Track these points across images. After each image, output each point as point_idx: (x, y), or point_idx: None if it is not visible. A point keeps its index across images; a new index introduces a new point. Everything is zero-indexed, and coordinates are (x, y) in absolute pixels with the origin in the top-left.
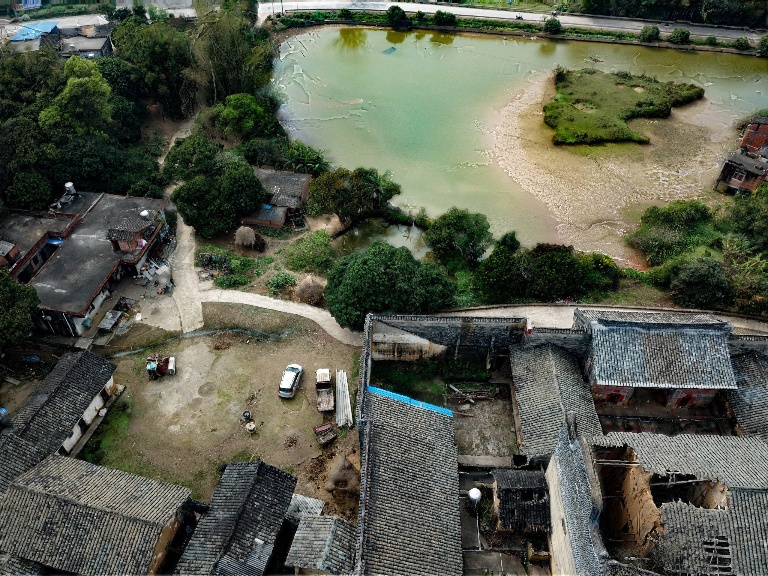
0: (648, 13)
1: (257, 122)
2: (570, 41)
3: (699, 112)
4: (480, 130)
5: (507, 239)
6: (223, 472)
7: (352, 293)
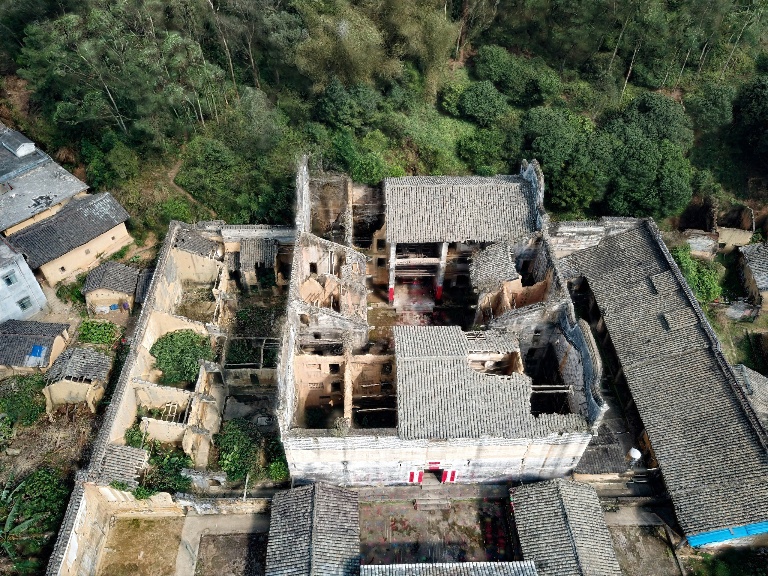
0: None
1: None
2: None
3: None
4: None
5: None
6: None
7: None
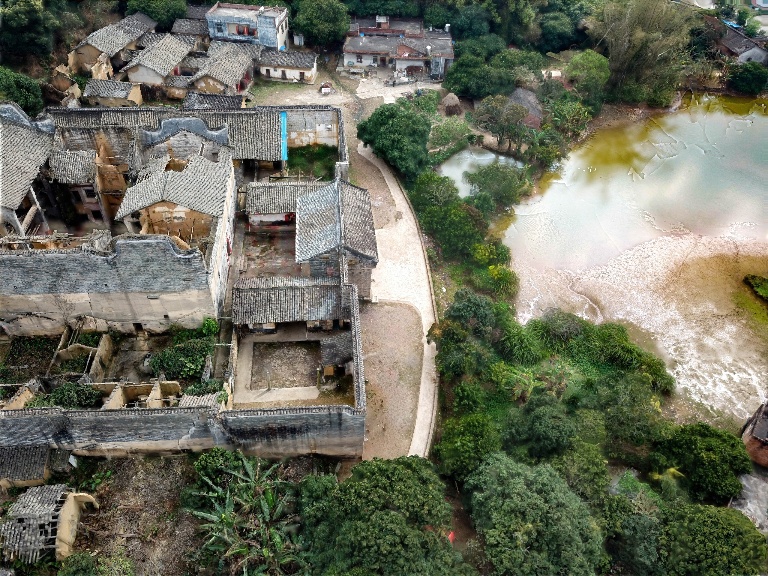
0: None
1: None
2: None
3: None
4: (729, 225)
5: (479, 193)
6: None
7: None
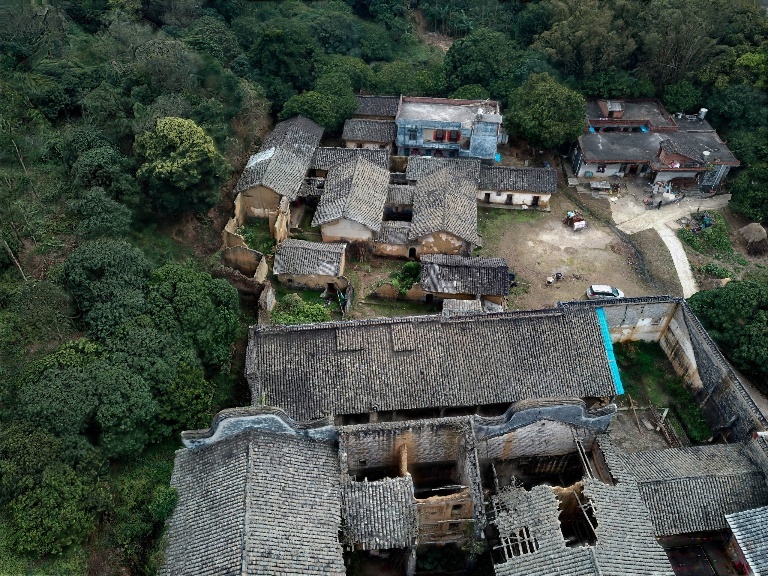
0: None
1: None
2: None
3: None
4: None
5: None
6: None
7: (714, 295)
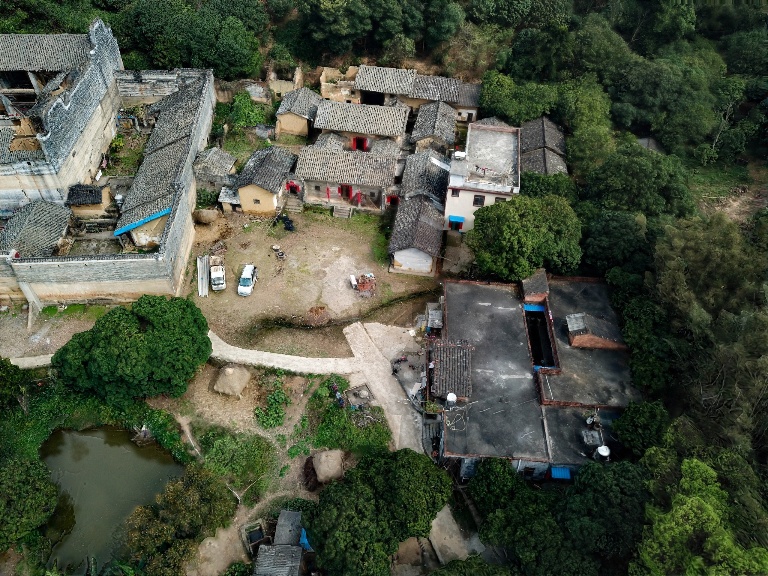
0: None
1: None
2: None
3: None
4: None
5: None
6: (292, 226)
7: None
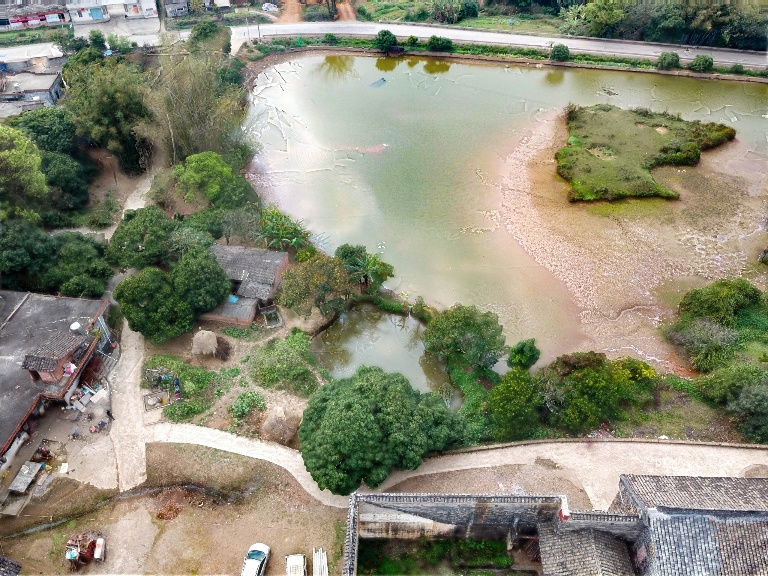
0: (665, 36)
1: (223, 186)
2: (580, 69)
3: (731, 157)
4: (484, 184)
5: (525, 350)
6: None
7: (333, 447)
